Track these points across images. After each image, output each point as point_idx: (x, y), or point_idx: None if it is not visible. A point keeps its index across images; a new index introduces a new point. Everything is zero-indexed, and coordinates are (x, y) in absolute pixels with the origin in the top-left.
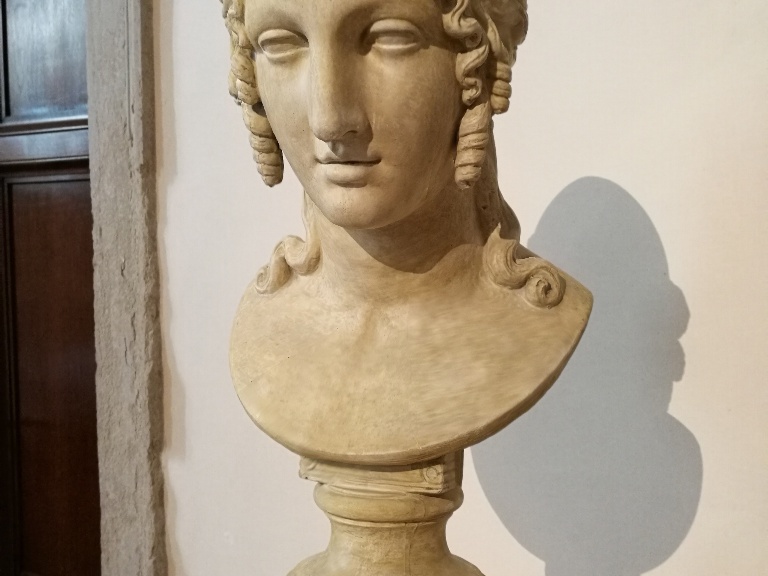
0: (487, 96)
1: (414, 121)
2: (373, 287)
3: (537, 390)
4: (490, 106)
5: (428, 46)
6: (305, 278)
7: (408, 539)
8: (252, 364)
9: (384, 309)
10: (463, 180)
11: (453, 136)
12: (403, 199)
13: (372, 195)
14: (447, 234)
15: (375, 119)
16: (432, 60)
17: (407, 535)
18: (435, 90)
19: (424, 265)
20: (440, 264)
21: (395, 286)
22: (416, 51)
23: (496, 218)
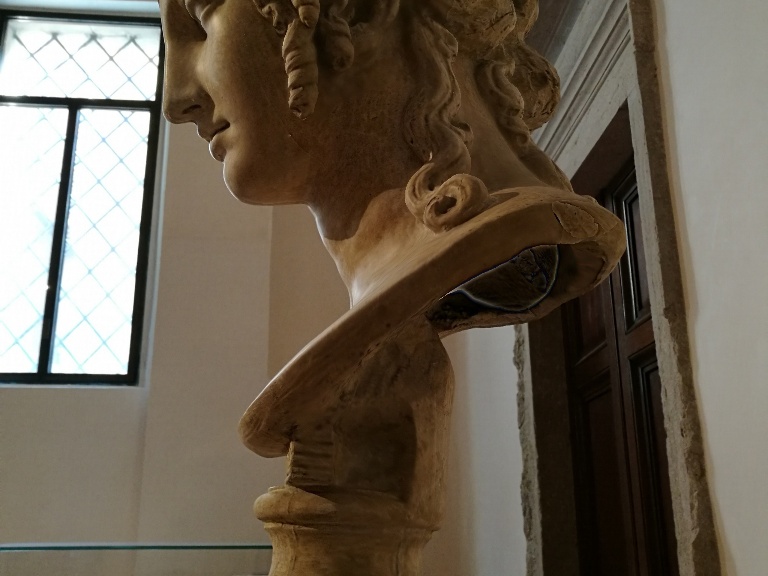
0: (294, 15)
1: (225, 72)
2: (340, 270)
3: (348, 324)
4: (299, 23)
5: (224, 1)
6: None
7: (293, 549)
8: None
9: None
10: (290, 109)
11: None
12: (259, 153)
13: None
14: (359, 183)
15: (208, 87)
16: (227, 11)
17: (291, 542)
18: (233, 35)
19: (351, 226)
20: (364, 220)
21: (344, 260)
22: (214, 11)
23: (426, 148)
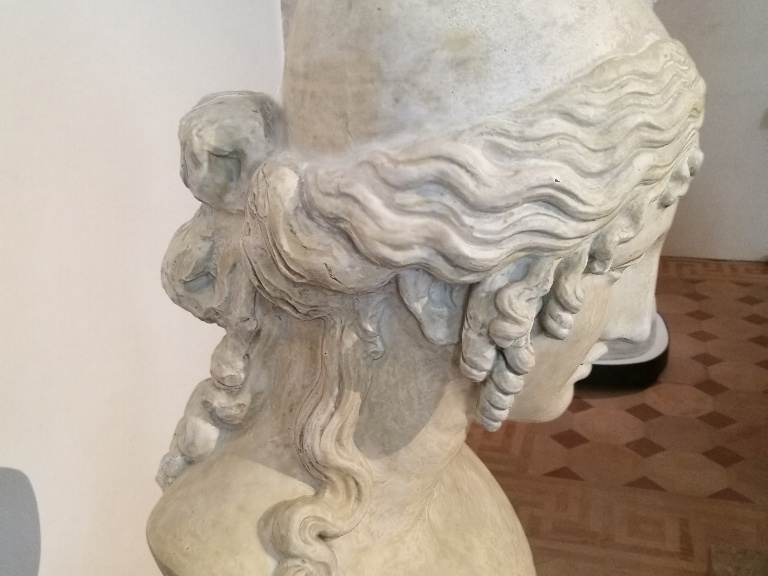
0: None
1: None
2: None
3: None
4: None
5: None
6: (344, 536)
7: None
8: None
9: None
10: None
11: None
12: None
13: None
14: None
15: None
16: None
17: None
18: None
19: None
20: None
21: None
22: None
23: None
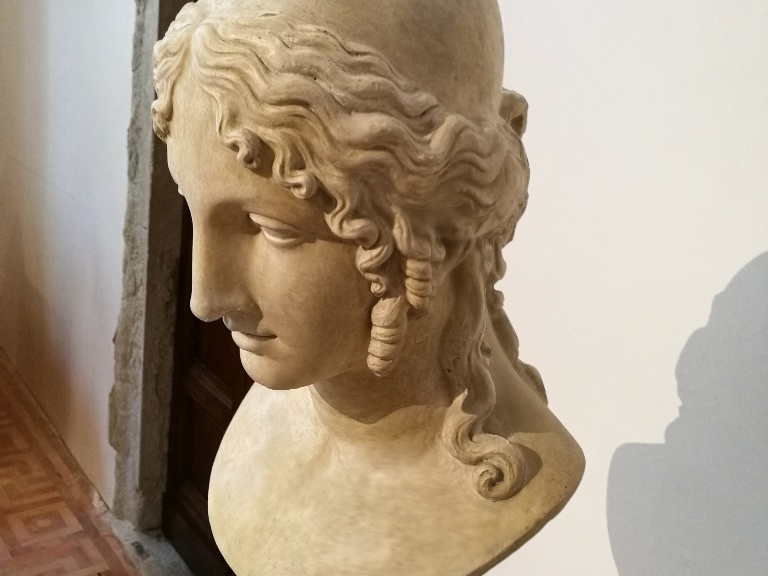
0: (401, 290)
1: (299, 312)
2: (326, 418)
3: None
4: (405, 300)
5: (314, 240)
6: None
7: None
8: (236, 441)
9: (337, 440)
10: (370, 369)
11: (369, 319)
12: (307, 373)
13: (269, 366)
14: (391, 395)
15: (261, 302)
16: (318, 255)
17: None
18: (322, 285)
19: (367, 417)
20: (385, 420)
21: (342, 426)
22: (298, 245)
23: (463, 384)
